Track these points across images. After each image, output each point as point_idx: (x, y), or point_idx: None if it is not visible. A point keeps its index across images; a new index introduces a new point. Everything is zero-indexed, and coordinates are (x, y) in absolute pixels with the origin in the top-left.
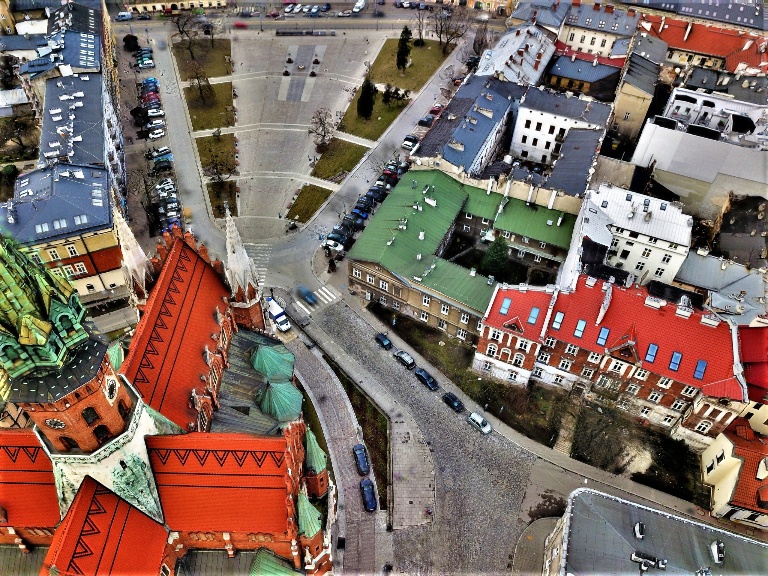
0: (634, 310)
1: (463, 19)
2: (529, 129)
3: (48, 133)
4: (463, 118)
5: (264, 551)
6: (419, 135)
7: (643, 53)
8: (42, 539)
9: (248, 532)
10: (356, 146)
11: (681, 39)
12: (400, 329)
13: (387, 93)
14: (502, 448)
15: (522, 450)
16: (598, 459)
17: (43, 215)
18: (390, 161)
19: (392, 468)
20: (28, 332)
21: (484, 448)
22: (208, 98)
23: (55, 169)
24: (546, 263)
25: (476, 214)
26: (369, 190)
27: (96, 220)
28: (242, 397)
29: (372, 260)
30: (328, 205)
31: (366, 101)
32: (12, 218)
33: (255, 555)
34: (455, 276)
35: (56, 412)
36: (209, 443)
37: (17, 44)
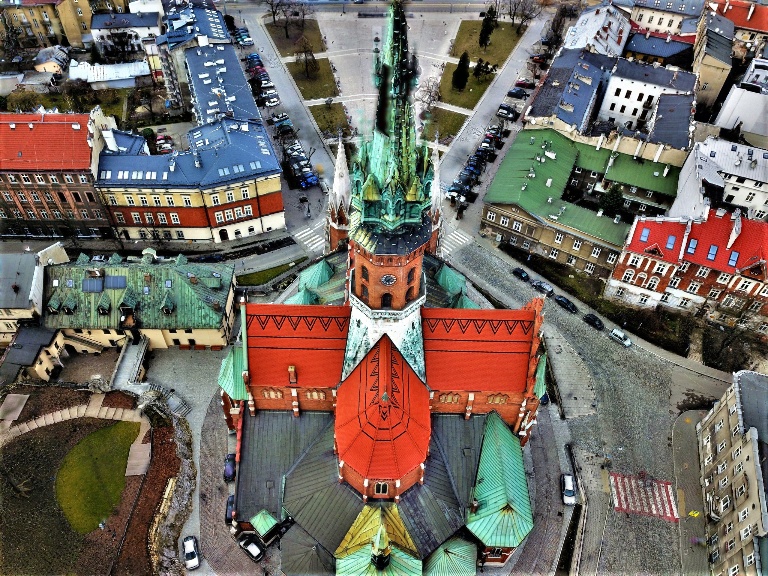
0: (760, 236)
1: (539, 1)
2: (618, 97)
3: (203, 94)
4: (567, 84)
5: (495, 414)
6: (510, 105)
7: (717, 29)
8: (312, 404)
9: (489, 394)
10: (456, 114)
11: (745, 19)
12: (535, 264)
13: (478, 67)
14: (643, 357)
15: (661, 359)
16: (727, 366)
17: (223, 161)
18: (490, 126)
19: (553, 372)
20: (416, 190)
21: (628, 357)
22: (313, 71)
23: (224, 123)
24: (650, 211)
25: (587, 168)
26: (477, 151)
27: (268, 166)
28: (436, 305)
29: (511, 202)
30: (442, 164)
31: (463, 73)
32: (198, 163)
33: (486, 418)
34: (584, 216)
35: (398, 267)
36: (472, 313)
37: (131, 22)
